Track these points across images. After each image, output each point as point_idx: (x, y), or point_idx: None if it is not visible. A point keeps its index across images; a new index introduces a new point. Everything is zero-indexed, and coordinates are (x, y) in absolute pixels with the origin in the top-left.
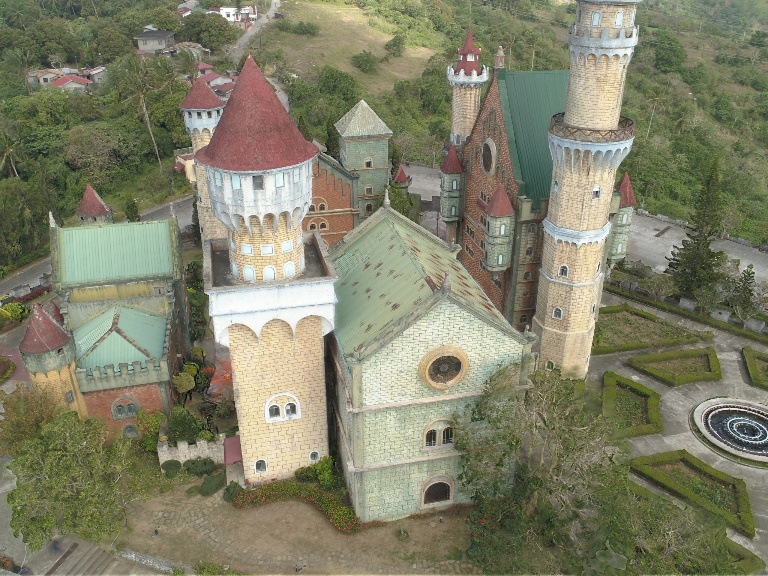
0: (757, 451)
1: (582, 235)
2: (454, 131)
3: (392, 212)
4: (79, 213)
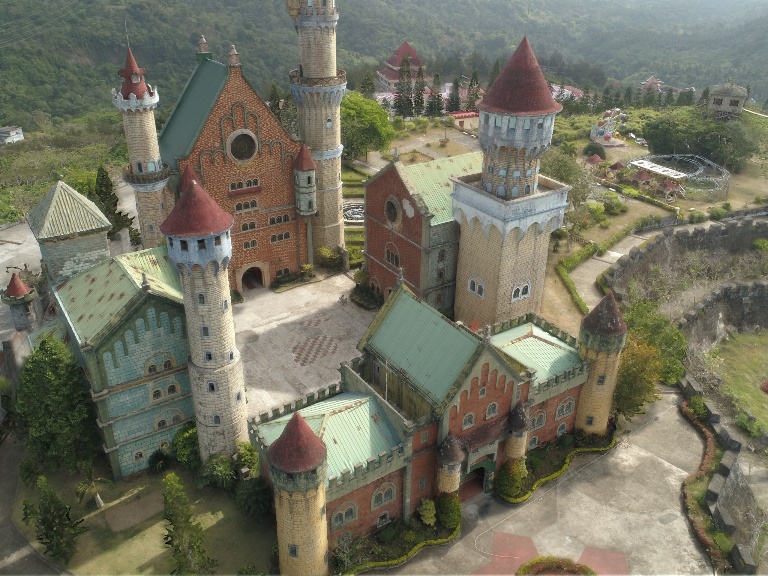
0: None
1: None
2: (154, 158)
3: None
4: (321, 459)
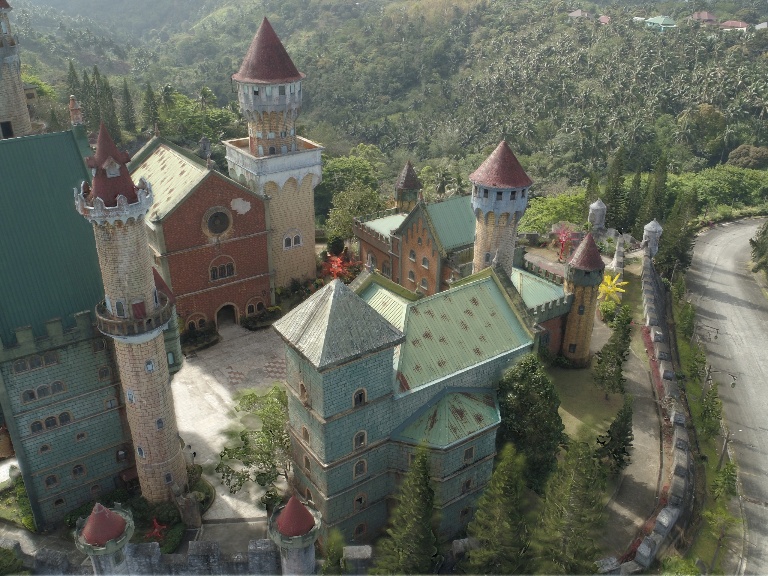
0: None
1: None
2: None
3: None
4: None
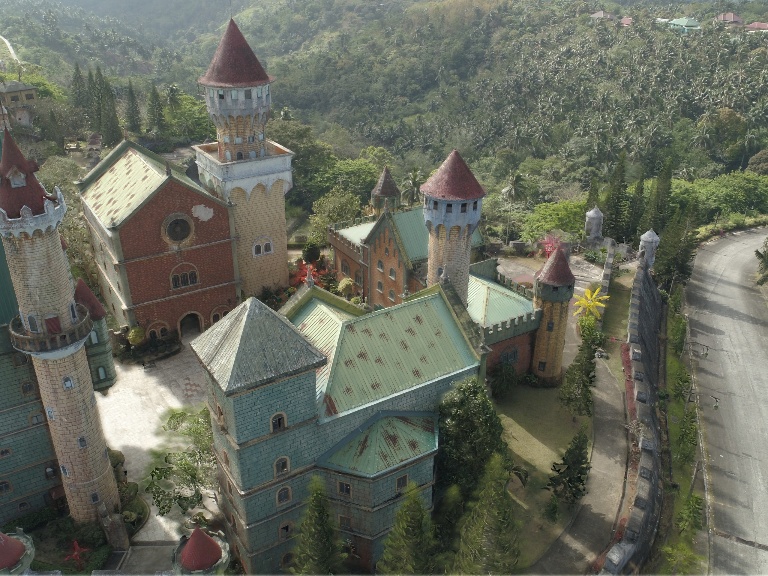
0: None
1: None
2: None
3: None
4: None
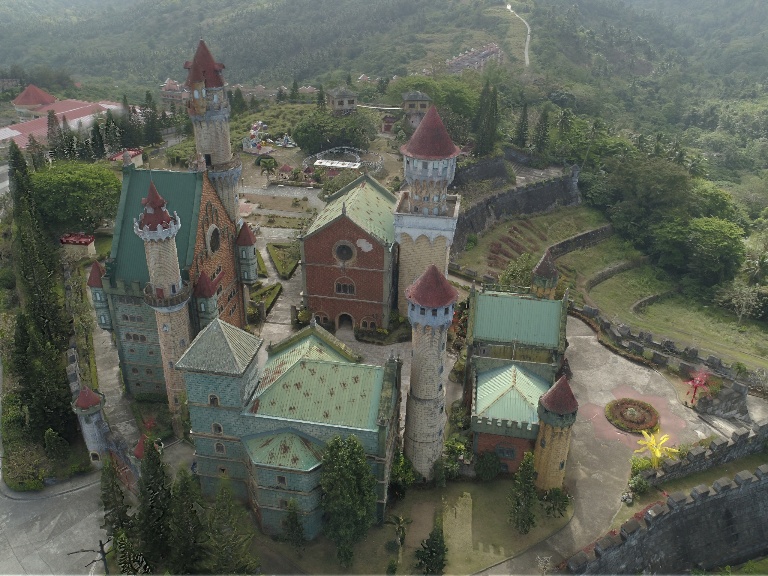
0: None
1: None
2: None
3: None
4: None
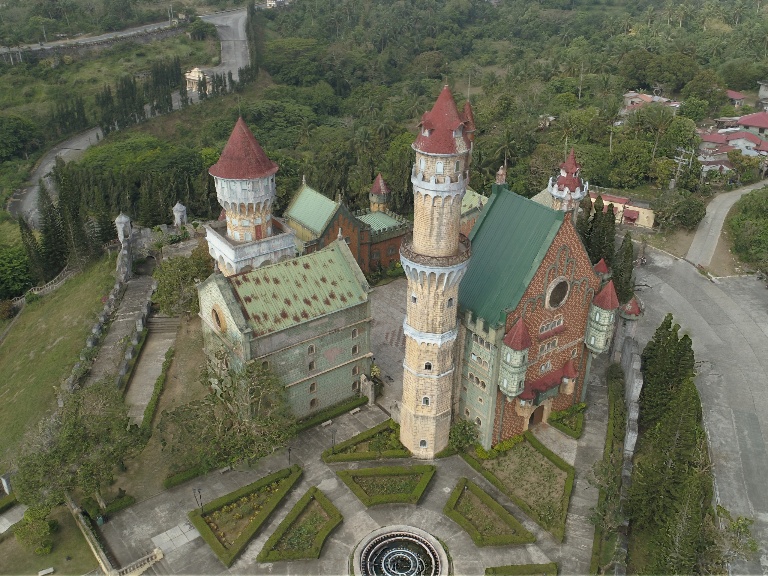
0: (377, 573)
1: (405, 326)
2: None
3: (338, 243)
4: None
